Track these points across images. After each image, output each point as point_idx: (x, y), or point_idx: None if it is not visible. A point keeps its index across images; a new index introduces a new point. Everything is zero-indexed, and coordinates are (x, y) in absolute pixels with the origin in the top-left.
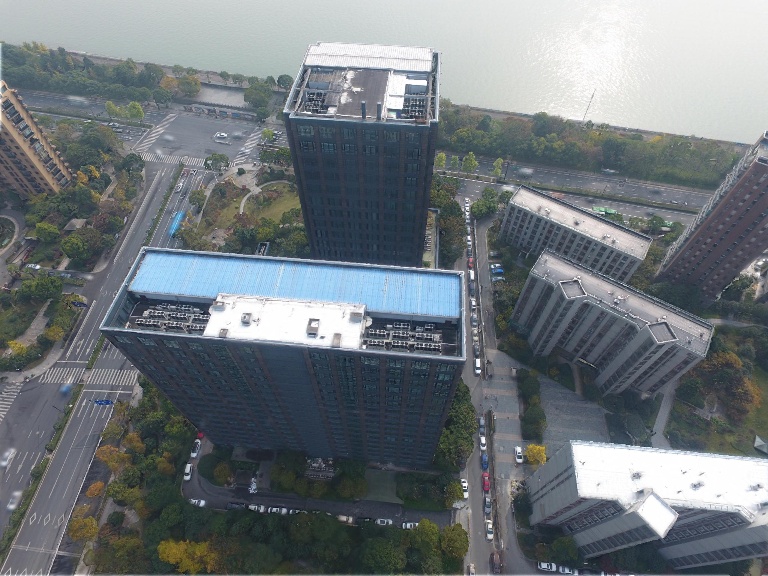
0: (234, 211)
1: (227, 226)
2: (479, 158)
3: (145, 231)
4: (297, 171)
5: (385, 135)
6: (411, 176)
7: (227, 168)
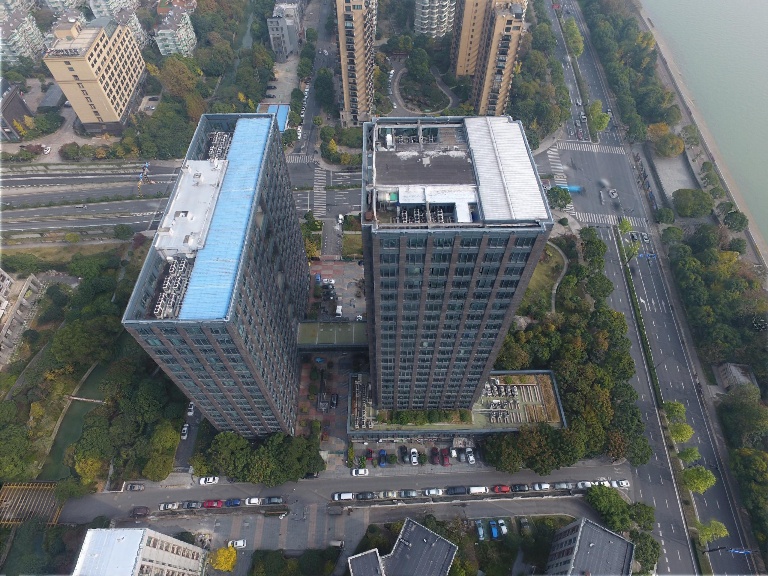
0: None
1: None
2: (740, 507)
3: None
4: None
5: None
6: None
7: (564, 210)
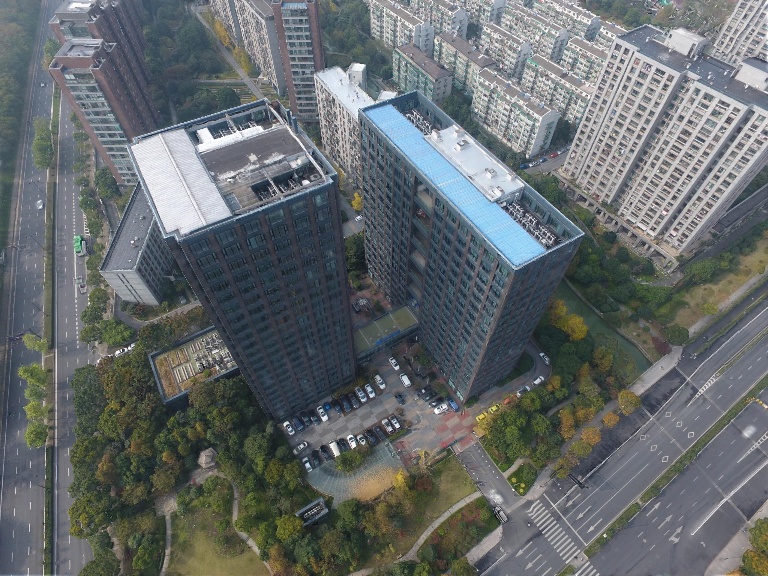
0: None
1: None
2: (0, 390)
3: None
4: None
5: None
6: None
7: None
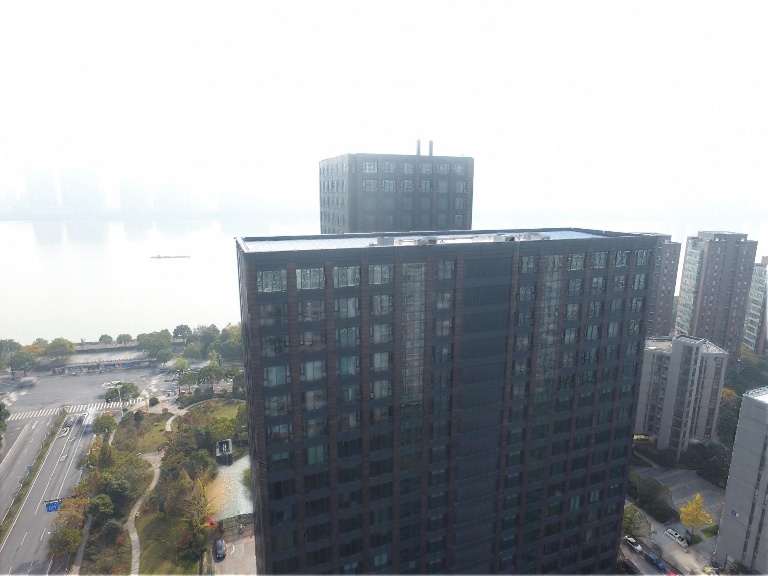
0: (159, 434)
1: (155, 448)
2: None
3: (16, 483)
4: (351, 223)
5: (438, 169)
6: (459, 212)
7: (132, 404)
